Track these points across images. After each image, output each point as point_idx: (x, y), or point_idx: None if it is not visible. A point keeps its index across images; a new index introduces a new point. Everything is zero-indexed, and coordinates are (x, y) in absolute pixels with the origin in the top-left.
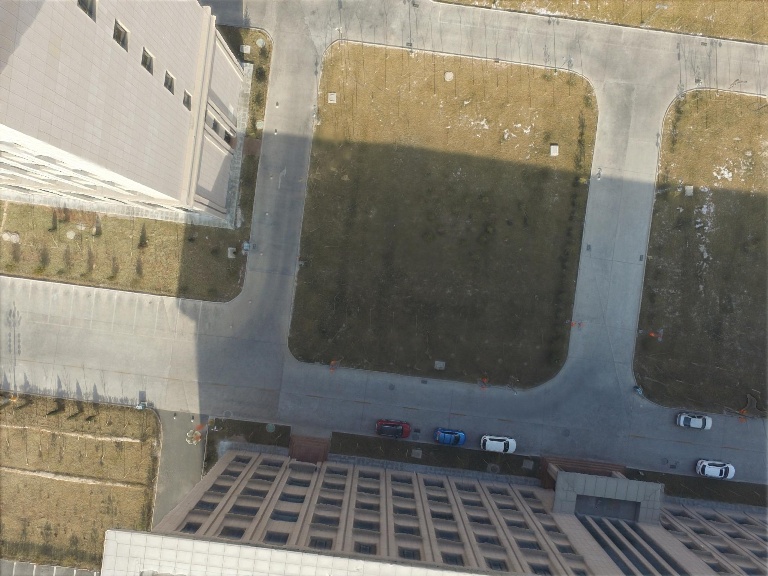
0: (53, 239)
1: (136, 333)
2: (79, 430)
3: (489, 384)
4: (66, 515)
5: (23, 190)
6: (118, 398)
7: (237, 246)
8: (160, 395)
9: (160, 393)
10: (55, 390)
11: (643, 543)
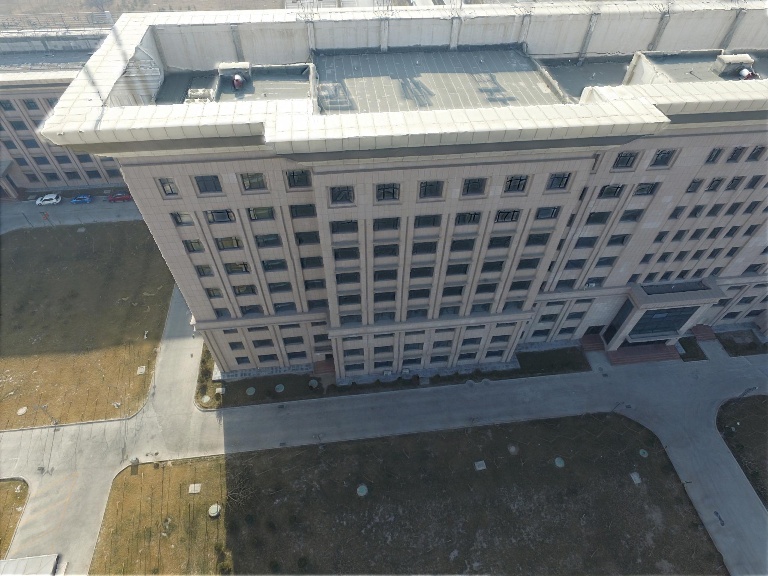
0: None
1: None
2: None
3: (41, 214)
4: None
5: None
6: None
7: None
8: None
9: None
10: None
11: None
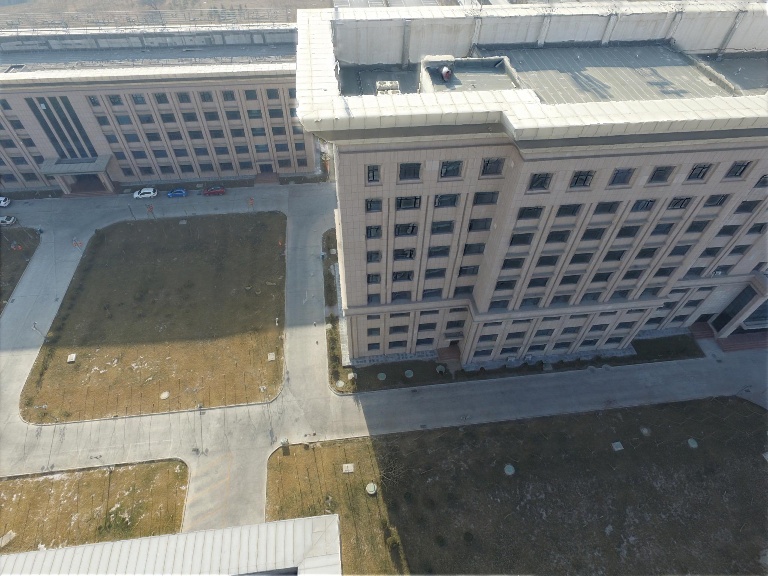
0: None
1: None
2: None
3: (146, 206)
4: None
5: None
6: None
7: (330, 256)
8: None
9: None
10: None
11: (58, 137)
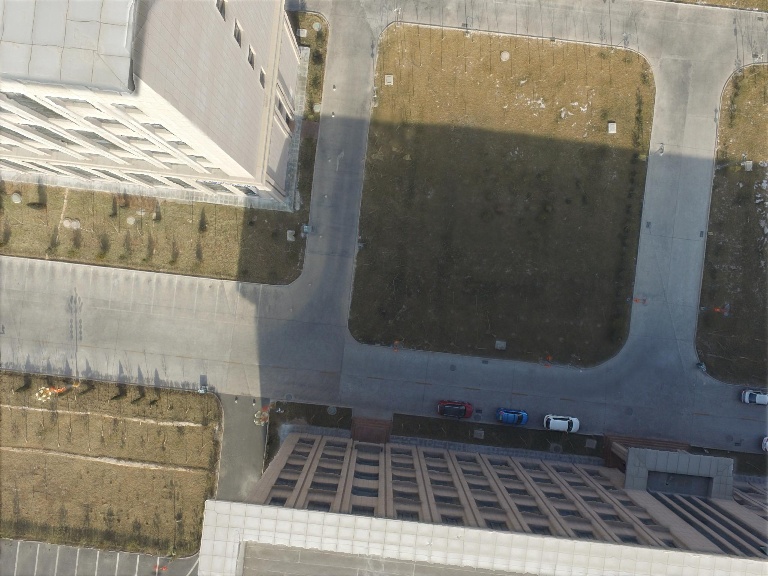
0: (113, 225)
1: (197, 317)
2: (141, 415)
3: (554, 362)
4: (129, 500)
5: (85, 176)
6: (179, 382)
7: (296, 229)
8: (221, 379)
9: (221, 377)
10: (117, 375)
11: (722, 517)
